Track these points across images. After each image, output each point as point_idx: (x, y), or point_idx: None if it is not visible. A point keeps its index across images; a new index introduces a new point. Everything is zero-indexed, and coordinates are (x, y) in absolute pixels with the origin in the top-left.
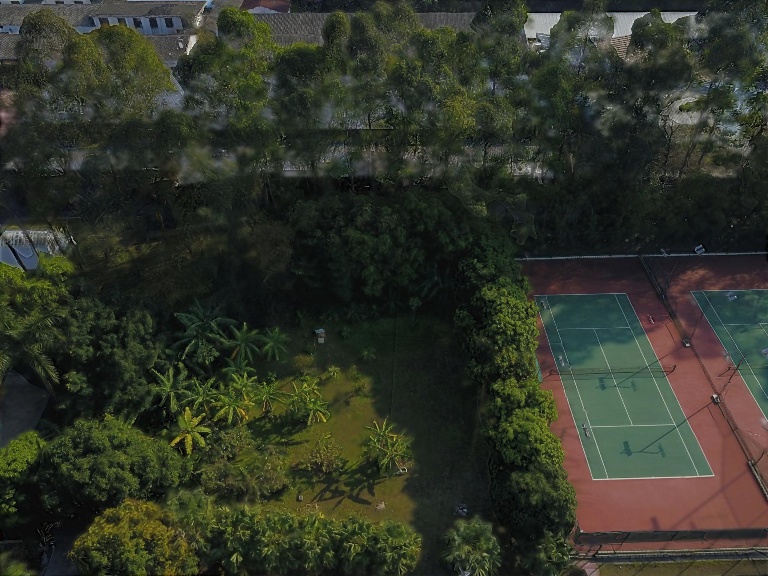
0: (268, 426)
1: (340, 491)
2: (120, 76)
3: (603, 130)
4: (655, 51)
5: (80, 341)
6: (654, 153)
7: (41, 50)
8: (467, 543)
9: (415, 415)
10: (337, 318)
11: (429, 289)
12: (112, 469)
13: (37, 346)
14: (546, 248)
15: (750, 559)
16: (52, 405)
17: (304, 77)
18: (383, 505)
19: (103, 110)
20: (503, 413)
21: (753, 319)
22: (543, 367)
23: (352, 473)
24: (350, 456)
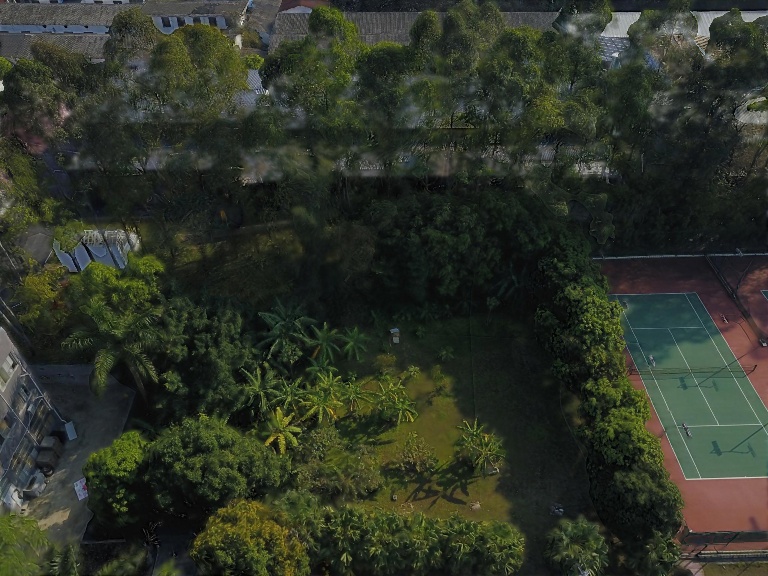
0: (353, 426)
1: (433, 491)
2: (203, 75)
3: None
4: (737, 50)
5: (176, 340)
6: (727, 152)
7: (130, 49)
8: (575, 543)
9: (499, 415)
10: (410, 318)
11: (505, 289)
12: (222, 469)
13: (136, 345)
14: (610, 248)
15: None
16: (137, 405)
17: (392, 76)
18: (478, 505)
19: (184, 109)
20: (599, 413)
21: None
22: None
23: (443, 473)
24: (439, 456)
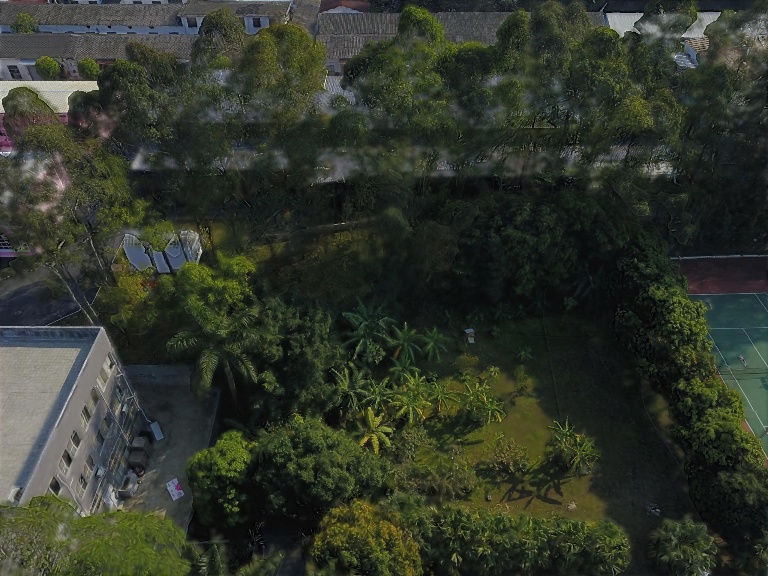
0: (439, 426)
1: (527, 491)
2: (286, 75)
3: None
4: None
5: (272, 341)
6: None
7: (218, 49)
8: (684, 543)
9: (584, 415)
10: (483, 318)
11: (582, 289)
12: (333, 469)
13: (235, 346)
14: (675, 248)
15: None
16: (223, 405)
17: (480, 76)
18: (574, 505)
19: (265, 109)
20: (694, 413)
21: None
22: None
23: (535, 473)
24: (529, 456)
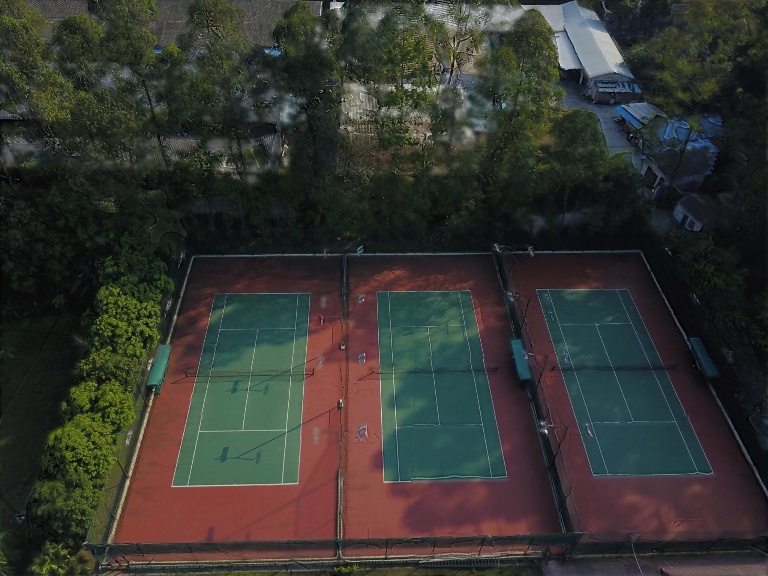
0: None
1: None
2: None
3: None
4: (290, 44)
5: None
6: (329, 150)
7: None
8: None
9: (25, 417)
10: None
11: (79, 286)
12: None
13: None
14: (254, 245)
15: (289, 570)
16: None
17: None
18: None
19: None
20: (66, 418)
21: (424, 322)
22: (183, 369)
23: None
24: None
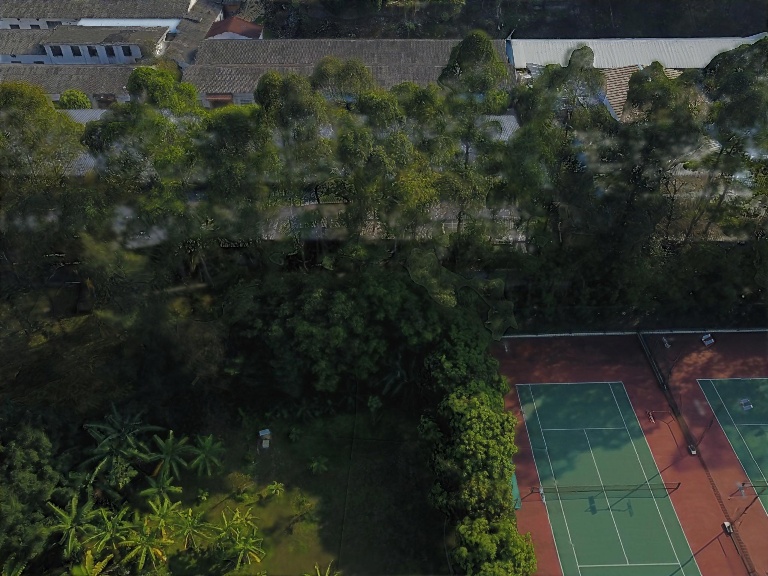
0: (193, 563)
1: None
2: (21, 142)
3: (596, 196)
4: (656, 113)
5: None
6: (655, 223)
7: None
8: None
9: (369, 548)
10: (286, 414)
11: (391, 385)
12: None
13: None
14: (531, 322)
15: None
16: None
17: (235, 149)
18: None
19: (4, 181)
20: (469, 567)
21: None
22: (524, 482)
23: None
24: None
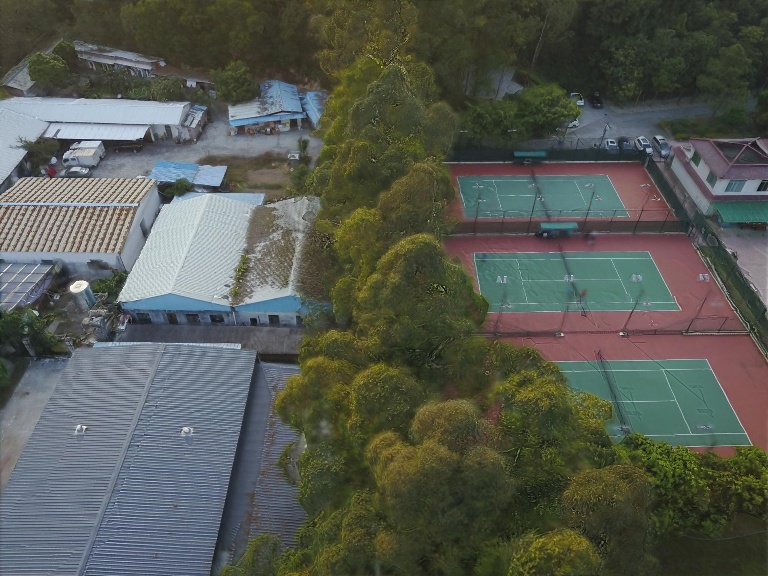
0: None
1: None
2: None
3: None
4: None
5: None
6: None
7: None
8: None
9: None
10: None
11: None
12: None
13: None
14: None
15: None
16: None
17: None
18: None
19: None
20: None
21: (516, 283)
22: None
23: None
24: None
